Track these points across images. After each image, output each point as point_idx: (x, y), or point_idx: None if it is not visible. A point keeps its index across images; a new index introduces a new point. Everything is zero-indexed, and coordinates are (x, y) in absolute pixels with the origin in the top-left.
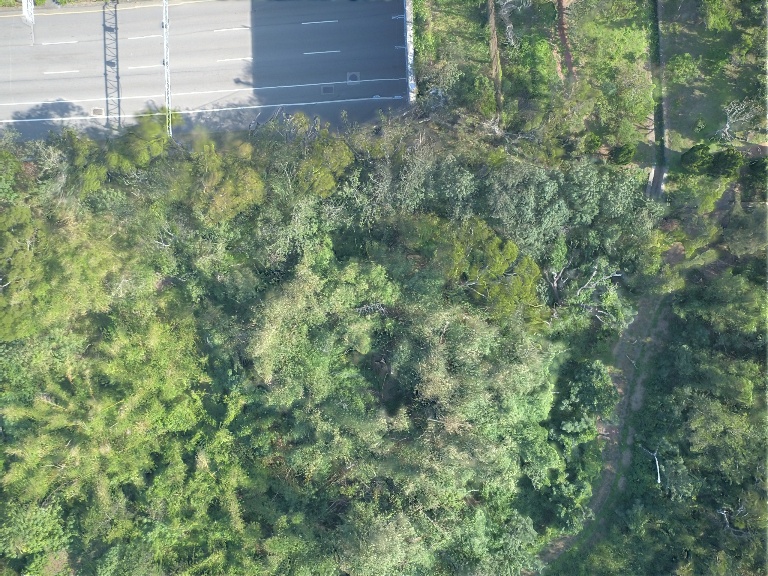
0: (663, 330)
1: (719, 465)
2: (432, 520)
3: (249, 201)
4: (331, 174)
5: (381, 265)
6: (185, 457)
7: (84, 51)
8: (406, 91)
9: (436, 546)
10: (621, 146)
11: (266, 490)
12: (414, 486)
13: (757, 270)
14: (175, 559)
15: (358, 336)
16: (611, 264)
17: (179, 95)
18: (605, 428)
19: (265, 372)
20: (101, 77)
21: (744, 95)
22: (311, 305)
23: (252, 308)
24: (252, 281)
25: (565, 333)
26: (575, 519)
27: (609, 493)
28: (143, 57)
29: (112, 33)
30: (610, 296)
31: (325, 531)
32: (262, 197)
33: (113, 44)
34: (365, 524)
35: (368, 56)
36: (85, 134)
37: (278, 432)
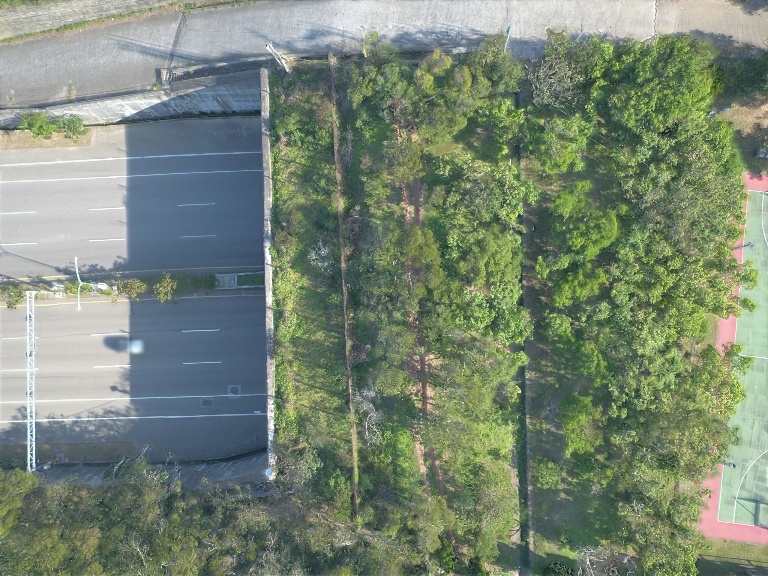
0: None
1: None
2: None
3: None
4: None
5: None
6: None
7: None
8: (265, 469)
9: None
10: (479, 561)
11: None
12: None
13: None
14: None
15: None
16: None
17: (53, 402)
18: None
19: None
20: None
21: (612, 501)
22: None
23: None
24: None
25: None
26: None
27: None
28: (17, 359)
29: None
30: None
31: None
32: None
33: None
34: None
35: (250, 368)
36: None
37: None
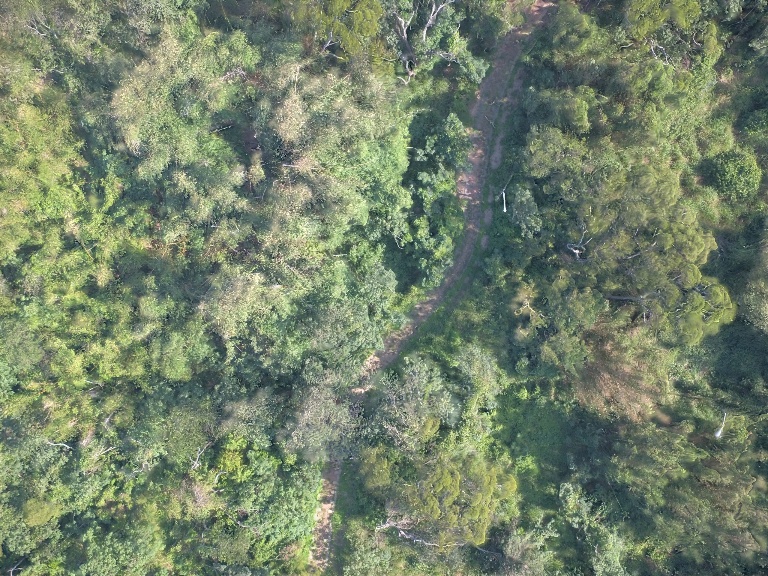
0: (518, 88)
1: (562, 193)
2: (292, 267)
3: None
4: None
5: (241, 30)
6: (66, 245)
7: None
8: None
9: (297, 293)
10: None
11: (141, 265)
12: (277, 242)
13: (603, 21)
14: (57, 343)
15: (215, 91)
16: (457, 12)
17: None
18: (467, 188)
19: (130, 137)
20: None
21: None
22: (176, 74)
23: (120, 82)
24: (123, 63)
25: (425, 97)
26: (434, 268)
27: (473, 252)
28: None
29: None
30: (456, 41)
31: (196, 298)
32: None
33: None
34: (231, 281)
35: None
36: None
37: (157, 218)
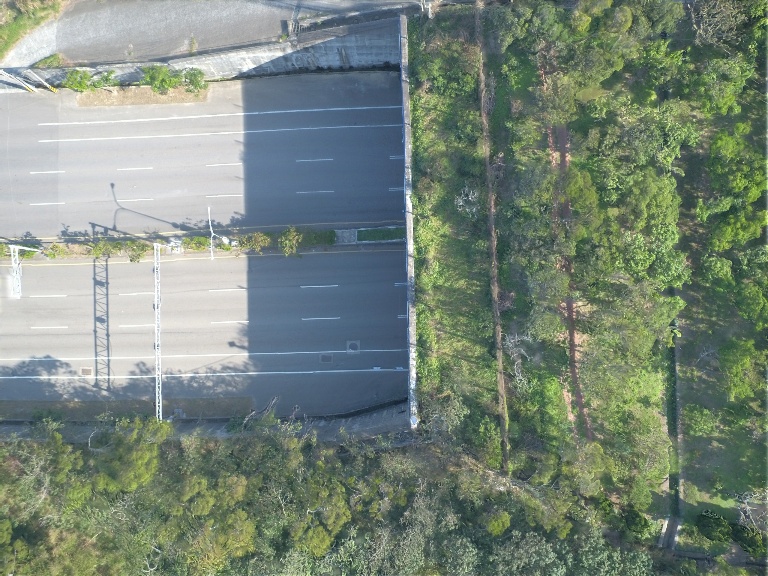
0: None
1: None
2: None
3: (239, 541)
4: (326, 531)
5: None
6: None
7: (73, 306)
8: (407, 418)
9: None
10: (633, 508)
11: None
12: None
13: None
14: None
15: None
16: None
17: (171, 357)
18: None
19: None
20: (90, 335)
21: (765, 449)
22: None
23: None
24: None
25: None
26: None
27: None
28: (134, 315)
29: (103, 287)
30: None
31: None
32: (253, 538)
33: (103, 299)
34: None
35: (369, 324)
36: (73, 394)
37: None
